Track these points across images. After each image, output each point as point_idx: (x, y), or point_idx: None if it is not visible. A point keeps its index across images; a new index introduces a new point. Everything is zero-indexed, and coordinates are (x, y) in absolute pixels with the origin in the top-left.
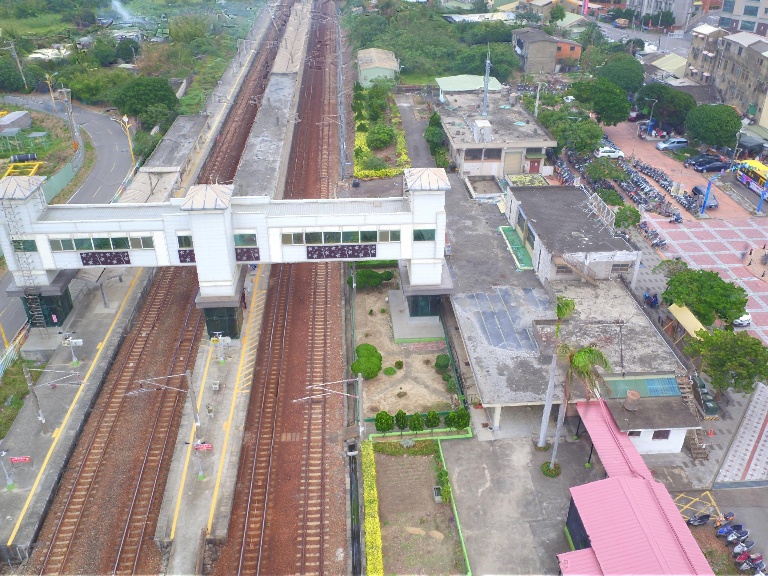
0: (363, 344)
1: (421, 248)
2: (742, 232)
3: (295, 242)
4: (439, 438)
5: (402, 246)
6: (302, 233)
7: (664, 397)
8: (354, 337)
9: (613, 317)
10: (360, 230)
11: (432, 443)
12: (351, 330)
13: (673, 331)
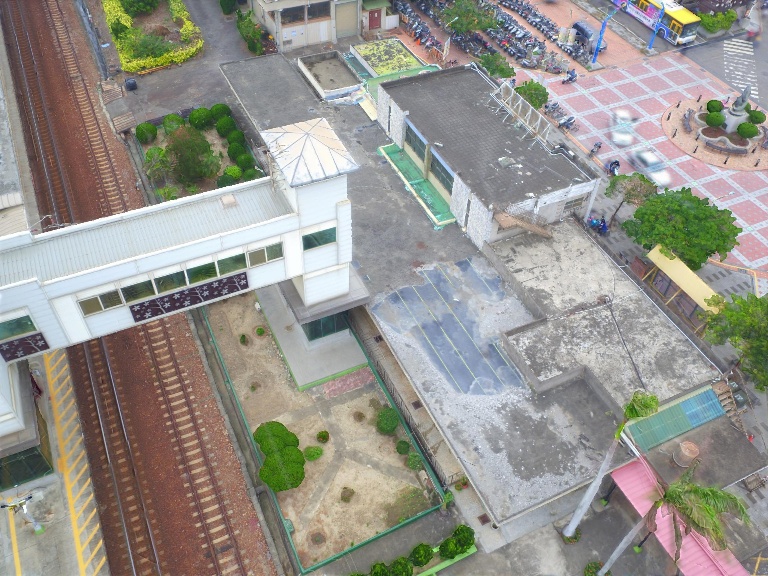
0: (263, 426)
1: (316, 257)
2: (645, 84)
3: (106, 306)
4: (434, 571)
5: (287, 262)
6: (115, 290)
7: (708, 423)
8: (236, 398)
9: (593, 292)
10: (216, 259)
11: None
12: (225, 383)
13: None
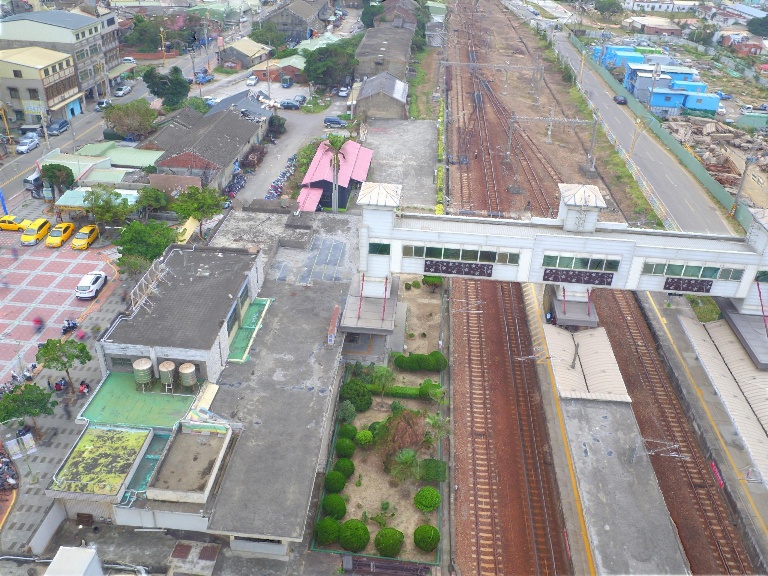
0: (437, 281)
1: None
2: None
3: None
4: None
5: None
6: None
7: None
8: None
9: (238, 244)
10: None
11: None
12: None
13: None
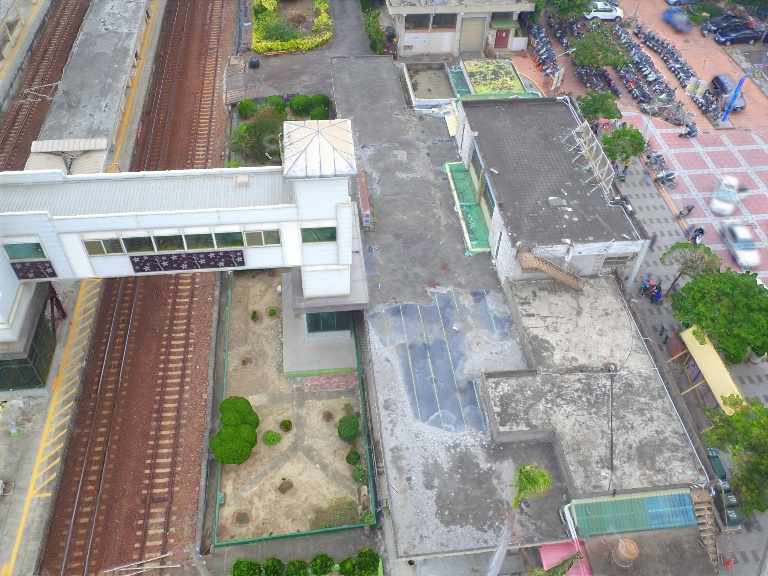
0: (230, 399)
1: (315, 252)
2: None
3: (109, 251)
4: None
5: (285, 250)
6: (117, 239)
7: (672, 529)
8: (225, 367)
9: (601, 357)
10: (213, 232)
11: None
12: (222, 351)
13: (681, 351)
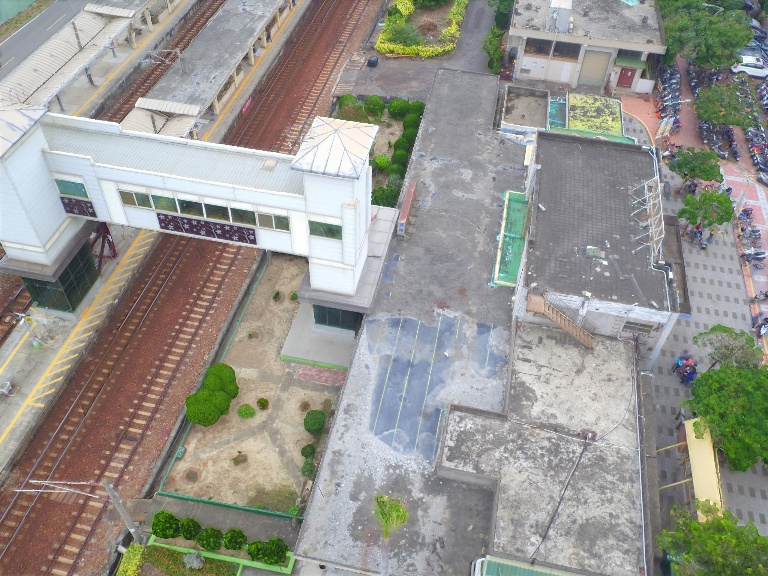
0: (218, 365)
1: (322, 246)
2: None
3: (140, 204)
4: (243, 563)
5: (294, 238)
6: (147, 194)
7: None
8: (232, 336)
9: (583, 422)
10: (229, 206)
11: (227, 572)
12: (236, 321)
13: None
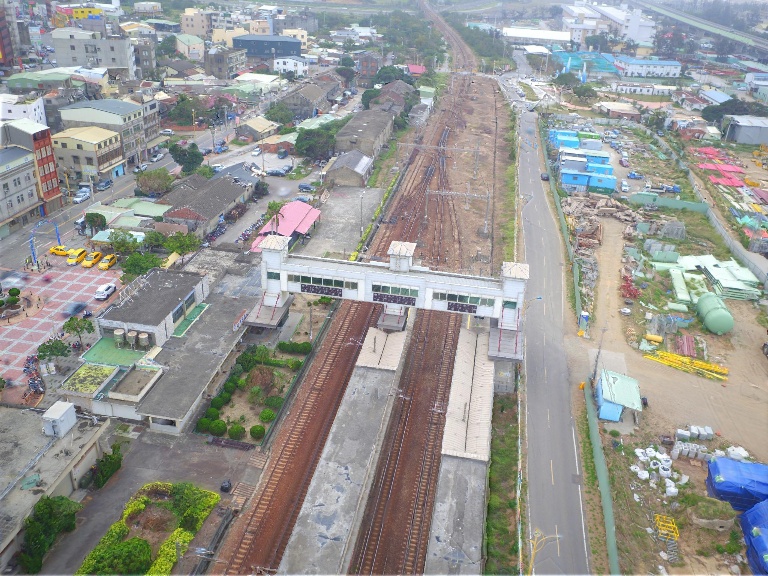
0: (326, 301)
1: None
2: None
3: None
4: None
5: None
6: None
7: None
8: None
9: (200, 270)
10: None
11: None
12: None
13: None
